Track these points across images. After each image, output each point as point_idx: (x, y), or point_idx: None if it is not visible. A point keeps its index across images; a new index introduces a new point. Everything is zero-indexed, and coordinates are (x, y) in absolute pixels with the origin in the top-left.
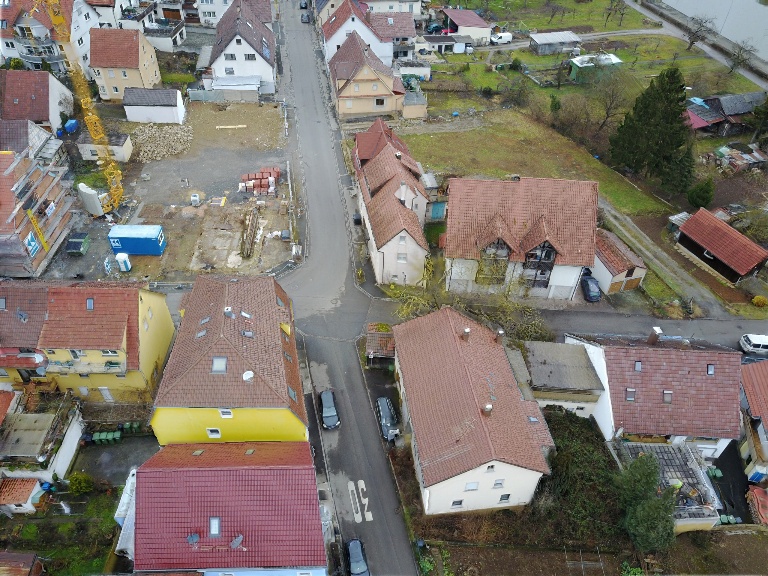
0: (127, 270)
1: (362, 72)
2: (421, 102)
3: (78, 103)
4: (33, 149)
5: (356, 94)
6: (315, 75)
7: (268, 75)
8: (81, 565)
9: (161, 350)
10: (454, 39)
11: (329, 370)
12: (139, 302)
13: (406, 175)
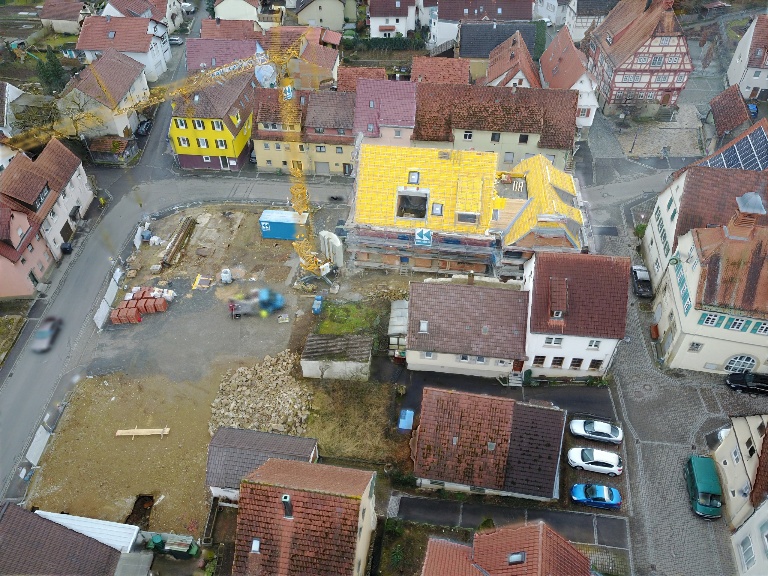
0: None
1: None
2: None
3: (408, 474)
4: None
5: None
6: None
7: None
8: None
9: None
10: None
11: (164, 151)
12: None
13: None
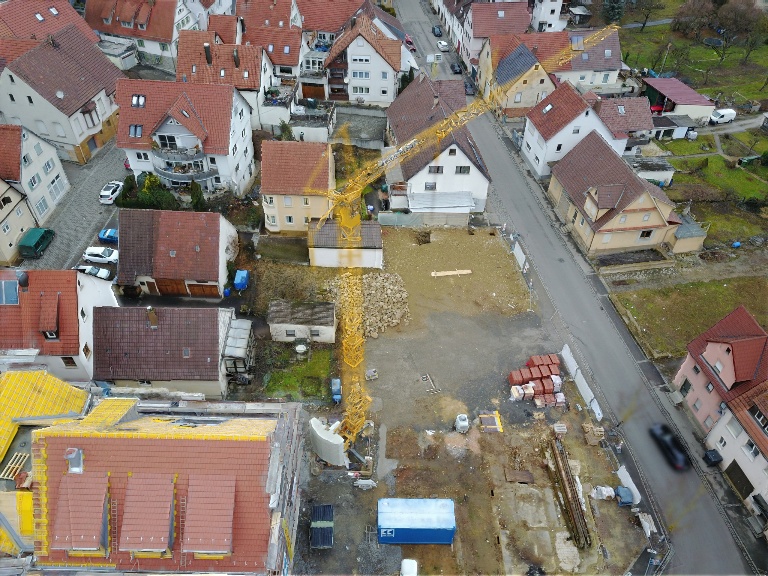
0: None
1: (637, 200)
2: (700, 233)
3: (242, 241)
4: (220, 345)
5: (619, 226)
6: (520, 179)
7: (481, 191)
8: None
9: None
10: (672, 121)
11: None
12: None
13: None
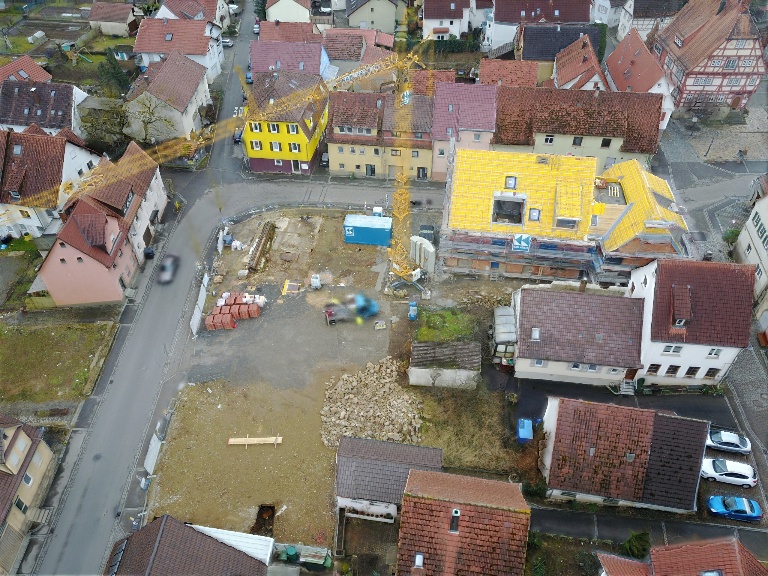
0: None
1: None
2: None
3: (538, 485)
4: None
5: None
6: None
7: None
8: None
9: None
10: None
11: (232, 154)
12: None
13: None
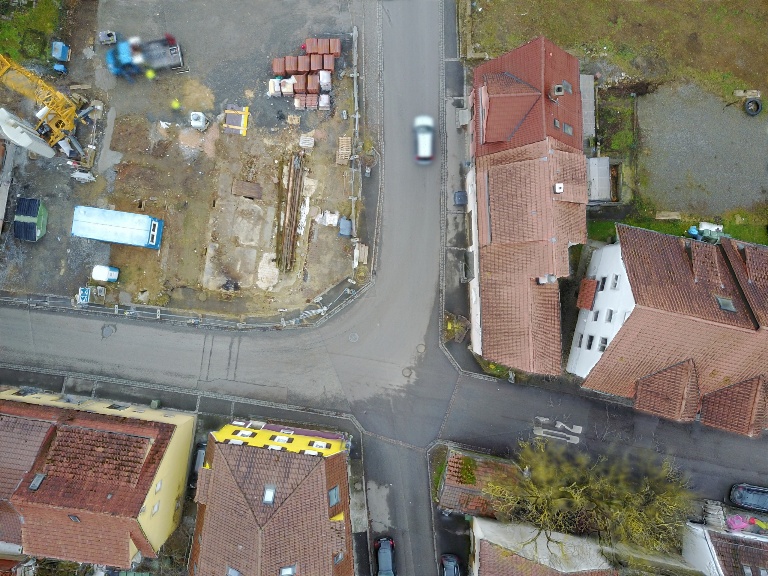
0: (113, 281)
1: None
2: None
3: None
4: None
5: None
6: None
7: None
8: None
9: (180, 473)
10: None
11: (390, 497)
12: (141, 520)
13: (561, 231)
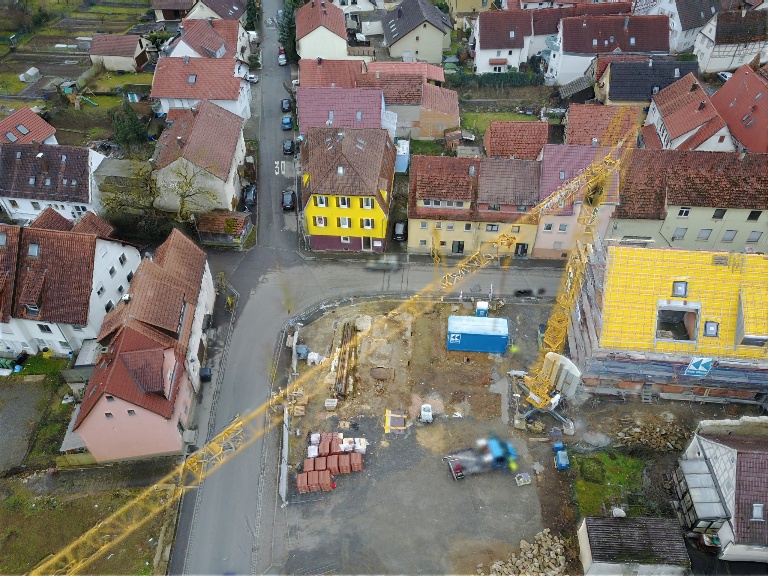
0: None
1: None
2: None
3: None
4: None
5: None
6: None
7: None
8: (426, 150)
9: None
10: None
11: (283, 226)
12: None
13: None
